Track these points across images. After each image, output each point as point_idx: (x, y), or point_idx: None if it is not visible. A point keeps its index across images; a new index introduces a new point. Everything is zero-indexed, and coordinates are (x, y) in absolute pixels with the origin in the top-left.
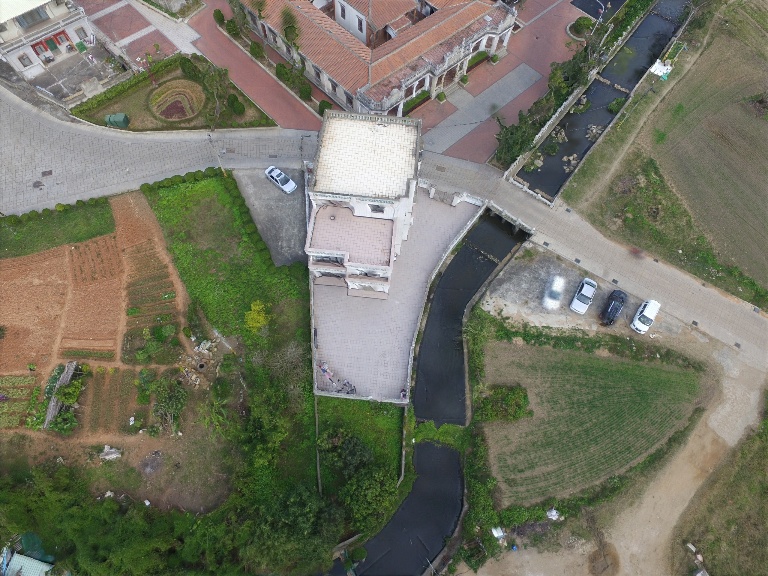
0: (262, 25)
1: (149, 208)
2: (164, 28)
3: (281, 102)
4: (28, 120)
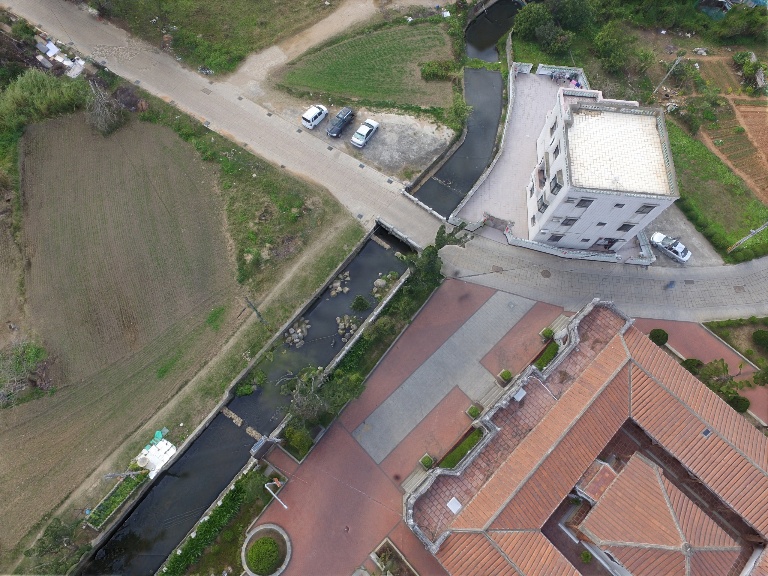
0: None
1: None
2: None
3: None
4: None
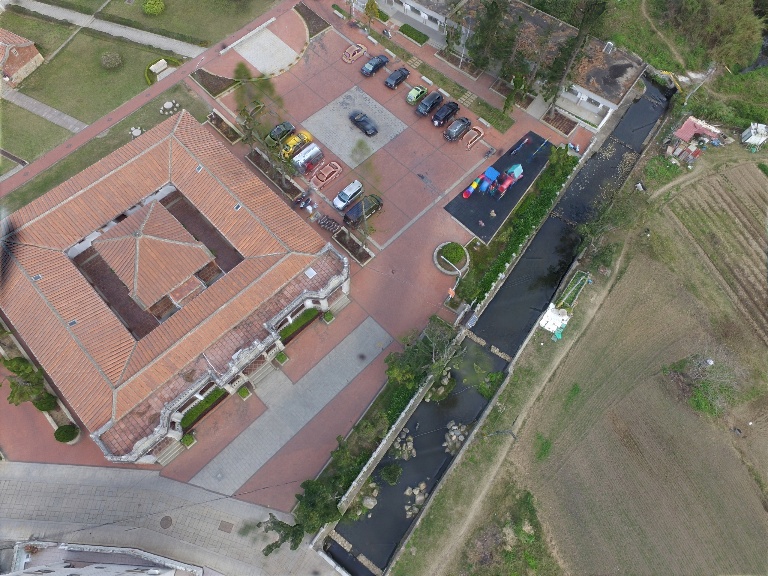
0: None
1: None
2: None
3: (17, 412)
4: None
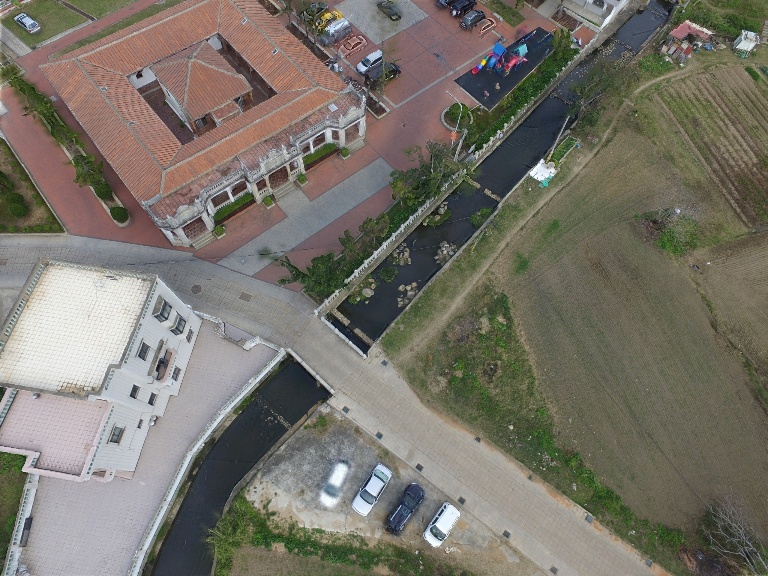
0: None
1: None
2: None
3: (78, 200)
4: None
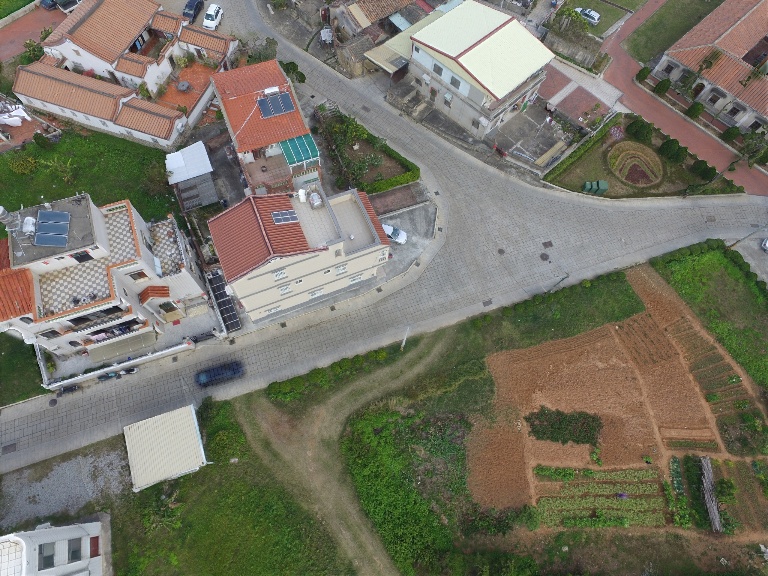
0: (698, 84)
1: (665, 283)
2: (586, 84)
3: None
4: (501, 186)
